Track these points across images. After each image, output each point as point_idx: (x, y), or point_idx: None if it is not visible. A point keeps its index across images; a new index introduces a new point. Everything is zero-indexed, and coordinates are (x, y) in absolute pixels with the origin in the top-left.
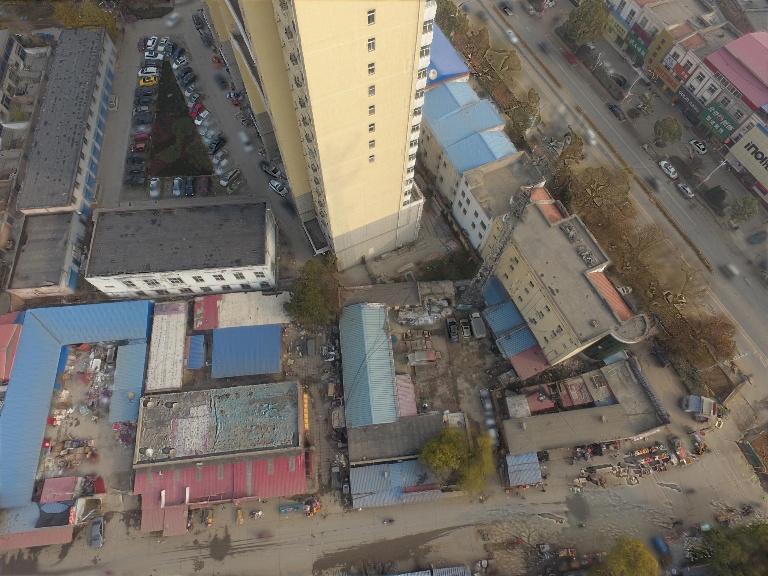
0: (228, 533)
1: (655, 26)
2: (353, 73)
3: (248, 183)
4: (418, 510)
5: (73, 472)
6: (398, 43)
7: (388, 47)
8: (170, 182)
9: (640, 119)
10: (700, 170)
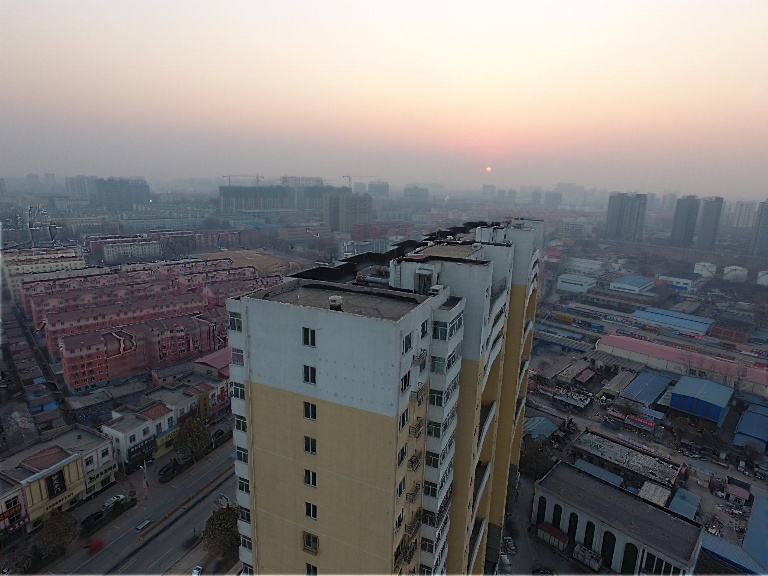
0: None
1: (191, 403)
2: None
3: (533, 569)
4: None
5: None
6: None
7: None
8: None
9: None
10: None
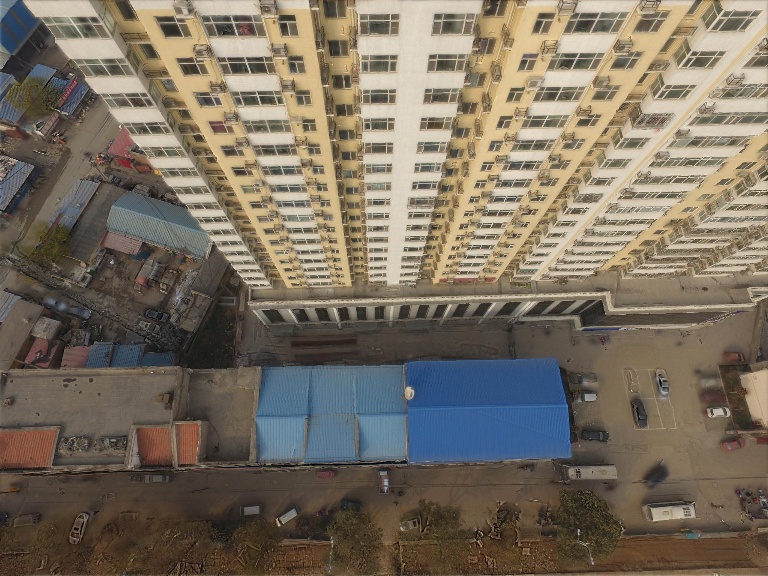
0: None
1: None
2: None
3: None
4: None
5: None
6: None
7: None
8: None
9: None
10: None
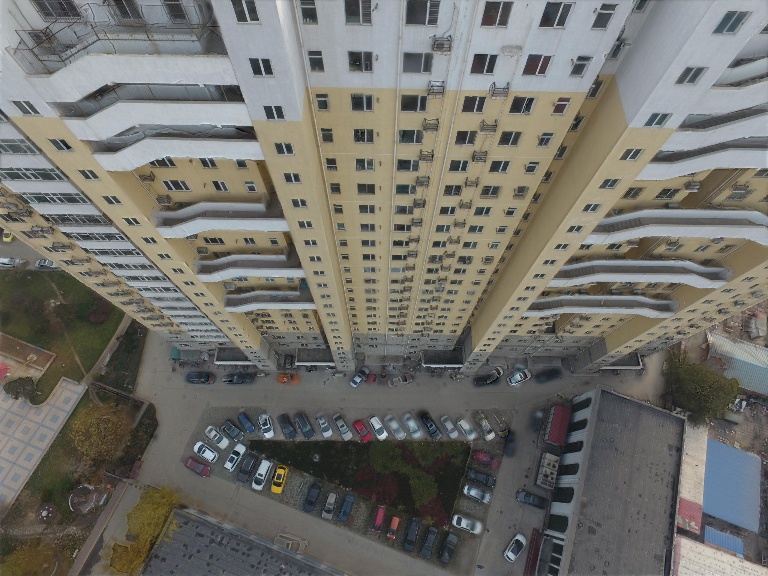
0: None
1: None
2: None
3: (500, 408)
4: None
5: None
6: None
7: None
8: (462, 502)
9: None
10: None
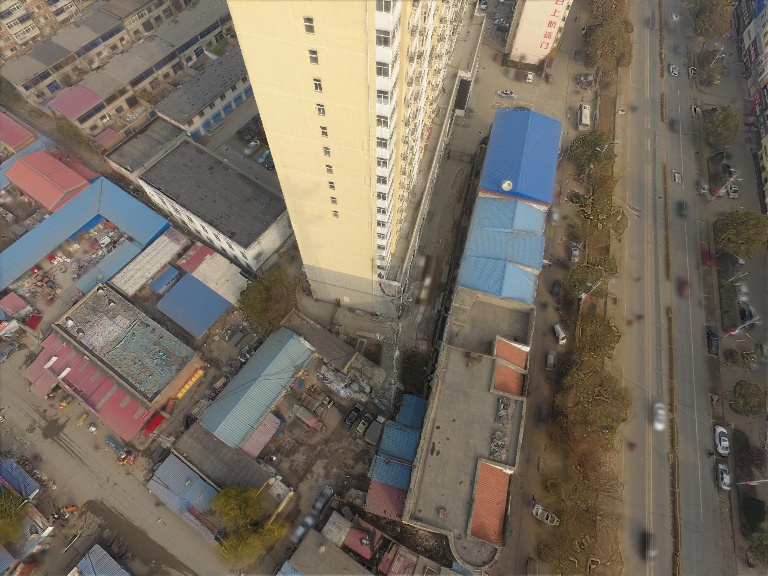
0: (66, 424)
1: None
2: (305, 126)
3: None
4: (189, 535)
5: (33, 301)
6: (350, 121)
7: (339, 120)
8: (266, 150)
9: (735, 367)
10: (764, 470)
